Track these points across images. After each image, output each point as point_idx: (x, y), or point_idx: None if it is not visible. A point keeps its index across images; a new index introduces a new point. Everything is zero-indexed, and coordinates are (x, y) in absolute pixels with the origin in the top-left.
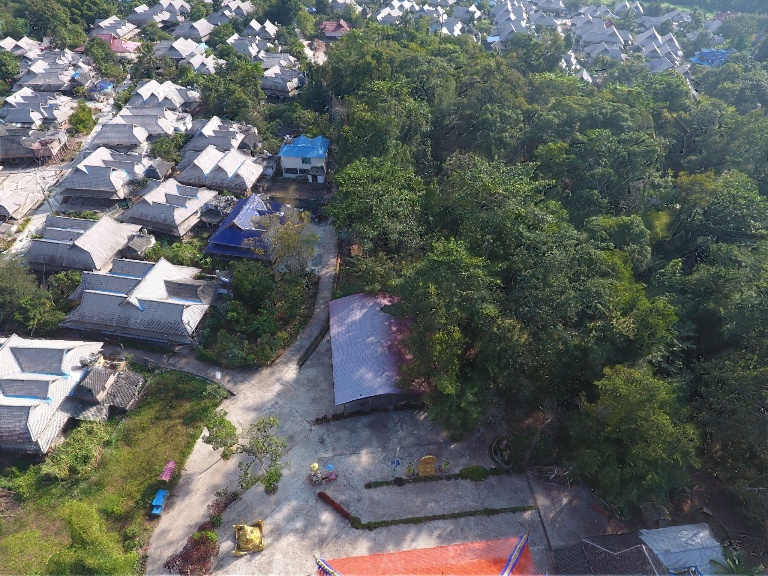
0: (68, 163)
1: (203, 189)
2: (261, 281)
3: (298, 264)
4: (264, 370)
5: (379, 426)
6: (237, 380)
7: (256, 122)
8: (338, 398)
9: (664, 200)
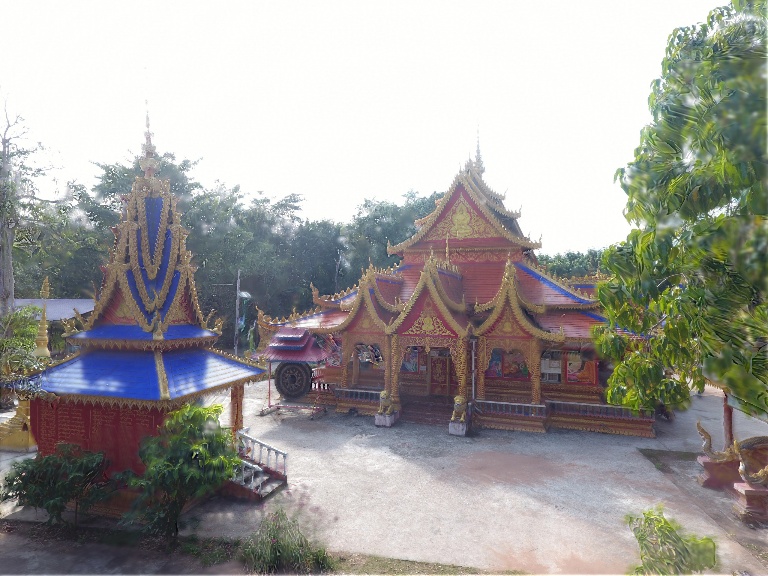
0: None
1: None
2: None
3: None
4: None
5: None
6: None
7: None
8: None
9: None
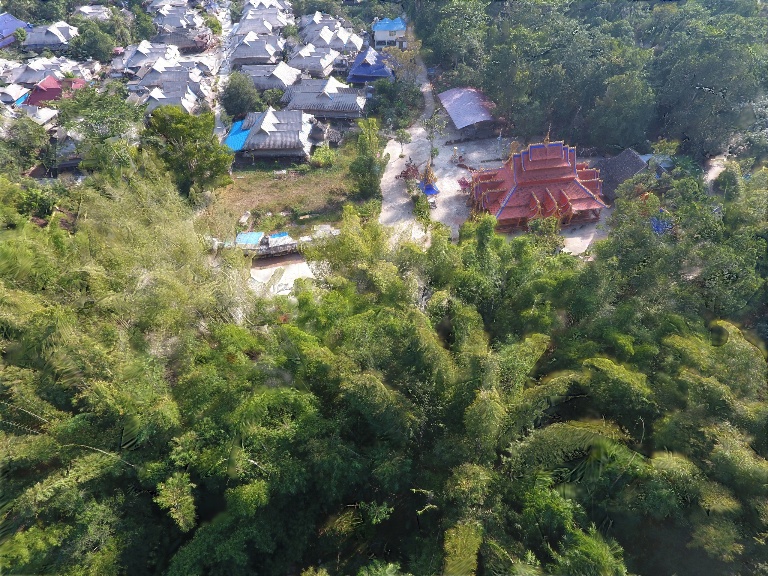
0: (228, 45)
1: (332, 50)
2: (395, 84)
3: (410, 82)
4: (407, 129)
5: (482, 144)
6: (393, 133)
7: (344, 17)
8: (459, 126)
9: (645, 28)
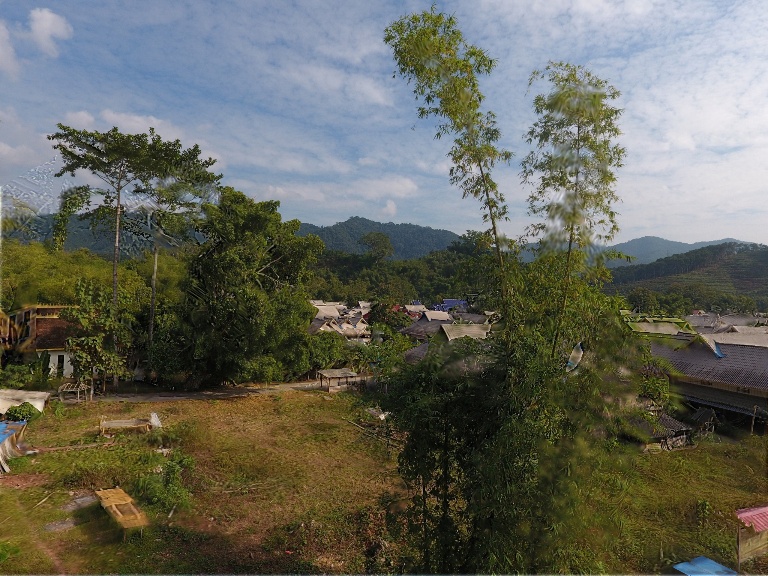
0: None
1: None
2: None
3: None
4: None
5: None
6: None
7: None
8: None
9: None
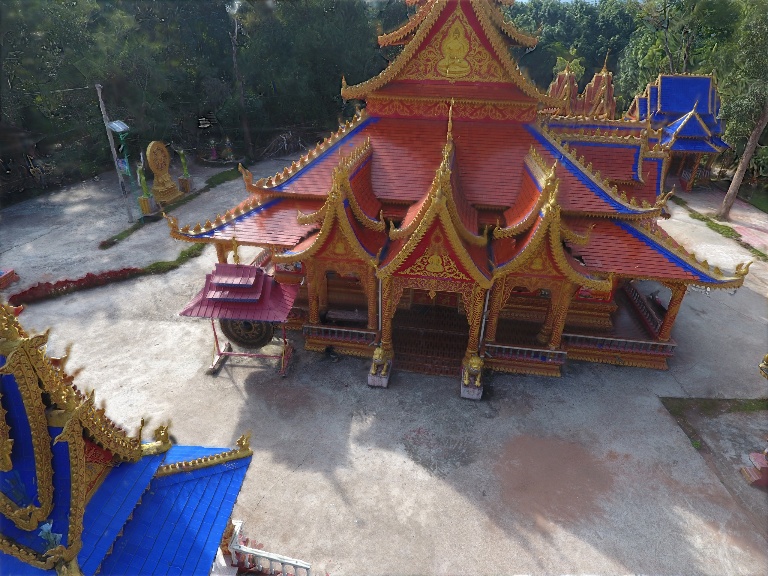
0: None
1: None
2: None
3: None
4: None
5: (5, 221)
6: None
7: None
8: None
9: None
